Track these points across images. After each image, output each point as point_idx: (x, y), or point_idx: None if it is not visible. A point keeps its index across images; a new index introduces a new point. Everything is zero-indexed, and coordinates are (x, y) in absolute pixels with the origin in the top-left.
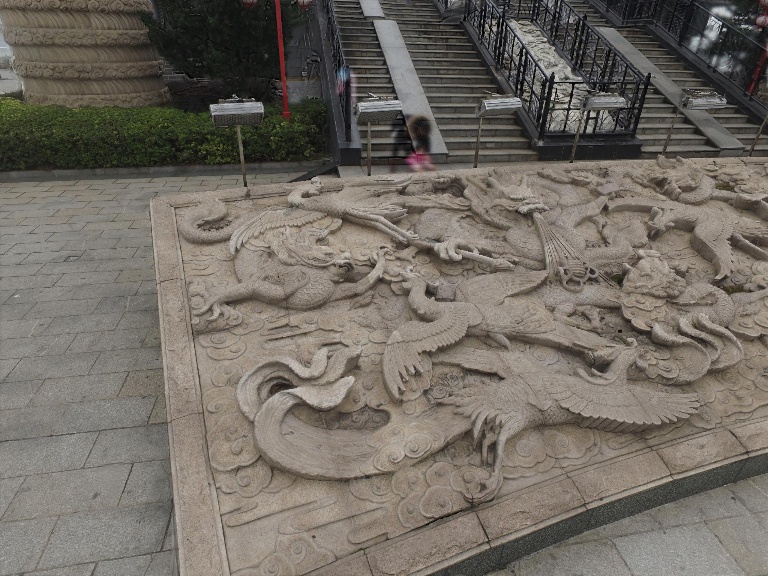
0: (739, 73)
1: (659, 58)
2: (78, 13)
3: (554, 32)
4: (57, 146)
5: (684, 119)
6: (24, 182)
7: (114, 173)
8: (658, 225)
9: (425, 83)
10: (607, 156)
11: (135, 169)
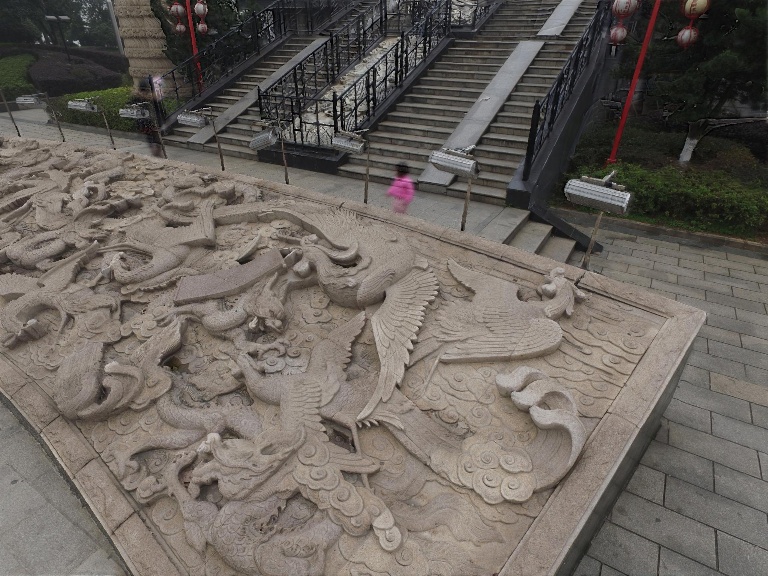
0: None
1: (547, 78)
2: (143, 39)
3: None
4: (95, 114)
5: None
6: (83, 131)
7: (117, 133)
8: (12, 183)
9: None
10: (310, 167)
11: (124, 132)
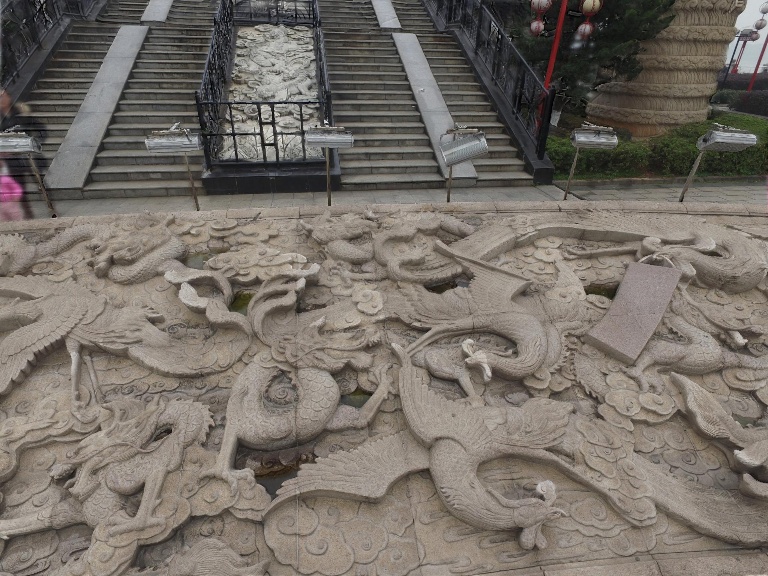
0: (509, 87)
1: (450, 68)
2: None
3: (317, 39)
4: None
5: (428, 141)
6: None
7: None
8: None
9: (136, 99)
10: (298, 188)
11: None
